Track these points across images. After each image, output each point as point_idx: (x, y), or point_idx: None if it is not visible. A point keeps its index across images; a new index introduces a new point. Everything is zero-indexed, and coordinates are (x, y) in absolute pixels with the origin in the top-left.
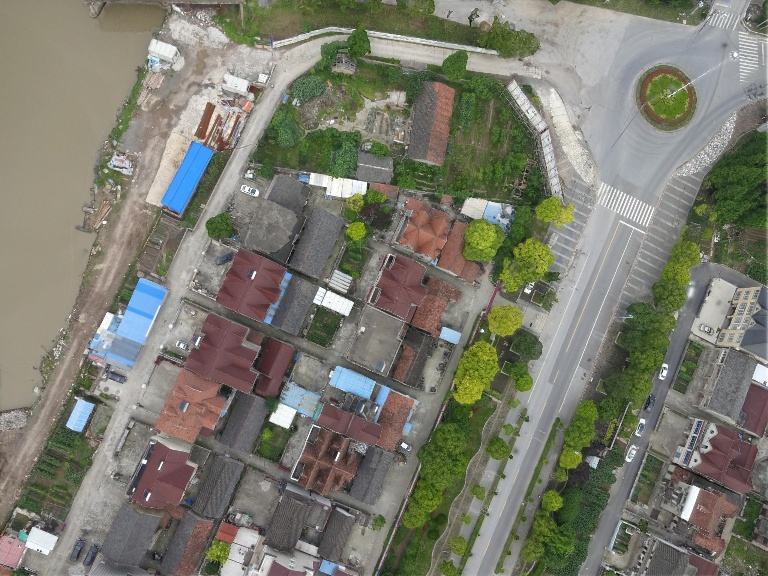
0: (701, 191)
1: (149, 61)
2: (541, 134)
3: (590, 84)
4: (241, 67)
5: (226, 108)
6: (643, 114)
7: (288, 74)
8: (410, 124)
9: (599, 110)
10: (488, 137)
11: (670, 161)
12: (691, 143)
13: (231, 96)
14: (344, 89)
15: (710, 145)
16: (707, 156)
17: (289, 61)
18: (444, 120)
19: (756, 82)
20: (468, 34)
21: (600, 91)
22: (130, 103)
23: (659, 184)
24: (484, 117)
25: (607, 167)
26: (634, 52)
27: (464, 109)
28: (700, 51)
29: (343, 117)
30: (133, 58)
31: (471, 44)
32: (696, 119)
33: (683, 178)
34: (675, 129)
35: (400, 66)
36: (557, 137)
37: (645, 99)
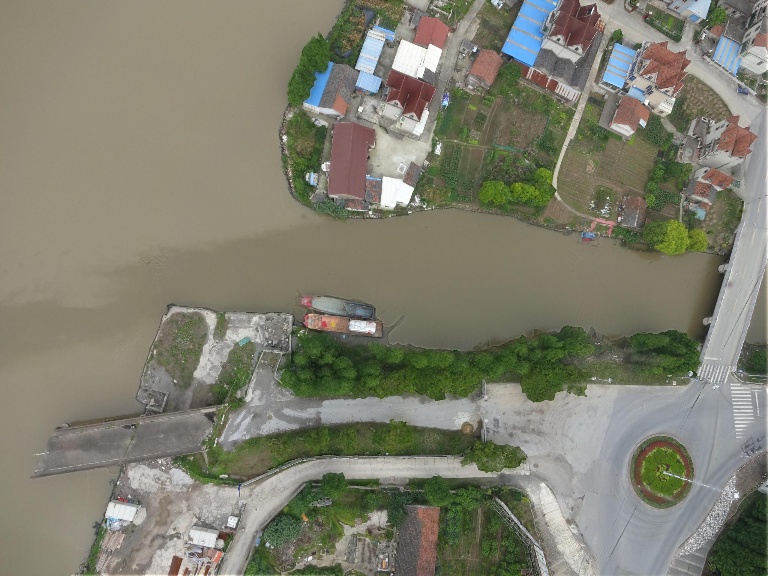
0: (706, 569)
1: (107, 520)
2: (534, 545)
3: (582, 471)
4: (208, 510)
5: (194, 559)
6: (639, 495)
7: (260, 512)
8: (394, 547)
9: (593, 498)
10: (478, 546)
11: (671, 540)
12: (691, 516)
13: (199, 545)
14: (321, 520)
15: (711, 515)
16: (709, 528)
17: (260, 497)
18: (430, 546)
19: (753, 436)
20: (450, 442)
21: (592, 477)
22: (88, 567)
23: (661, 568)
24: (472, 525)
25: (606, 559)
26: (625, 427)
27: (451, 525)
28: (693, 412)
29: (322, 550)
30: (90, 509)
31: (454, 450)
32: (694, 489)
33: (686, 557)
34: (674, 505)
35: (380, 490)
36: (551, 536)
37: (640, 479)
